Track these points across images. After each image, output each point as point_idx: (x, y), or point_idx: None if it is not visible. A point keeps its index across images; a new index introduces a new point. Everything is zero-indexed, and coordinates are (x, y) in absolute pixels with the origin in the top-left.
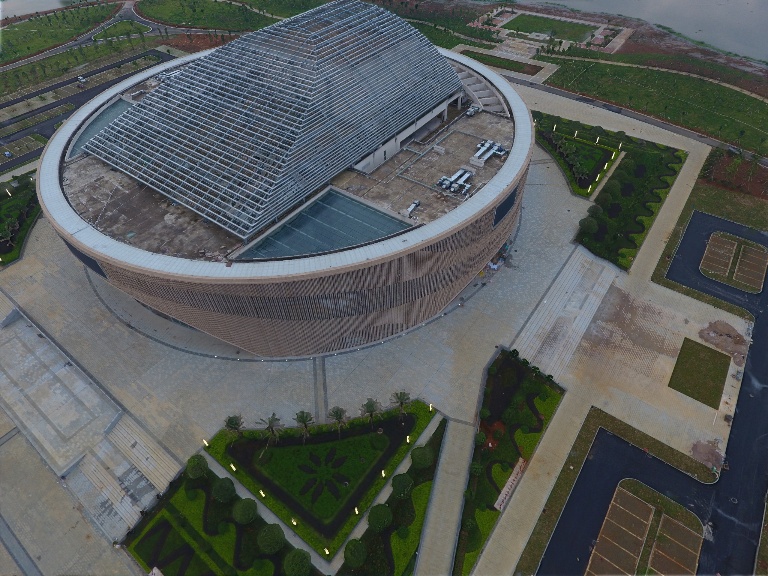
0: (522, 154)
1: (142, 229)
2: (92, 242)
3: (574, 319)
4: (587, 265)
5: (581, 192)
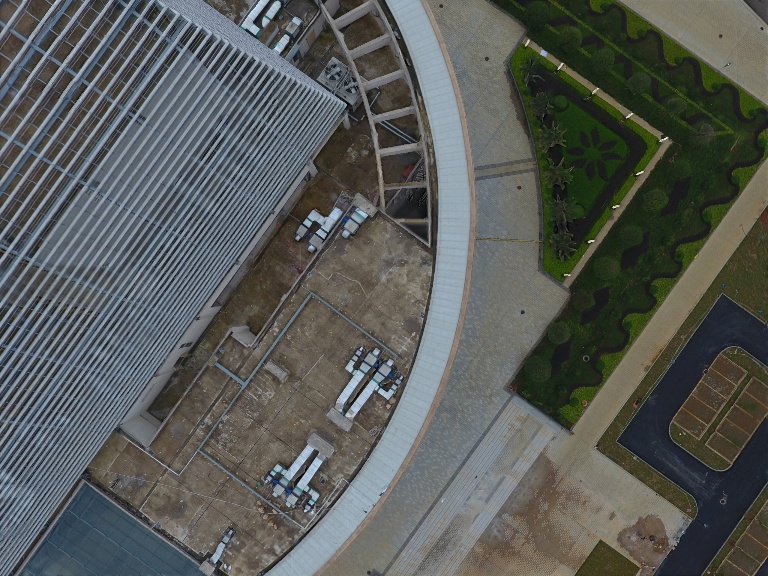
0: (425, 396)
1: None
2: None
3: (474, 519)
4: (518, 424)
5: (554, 271)
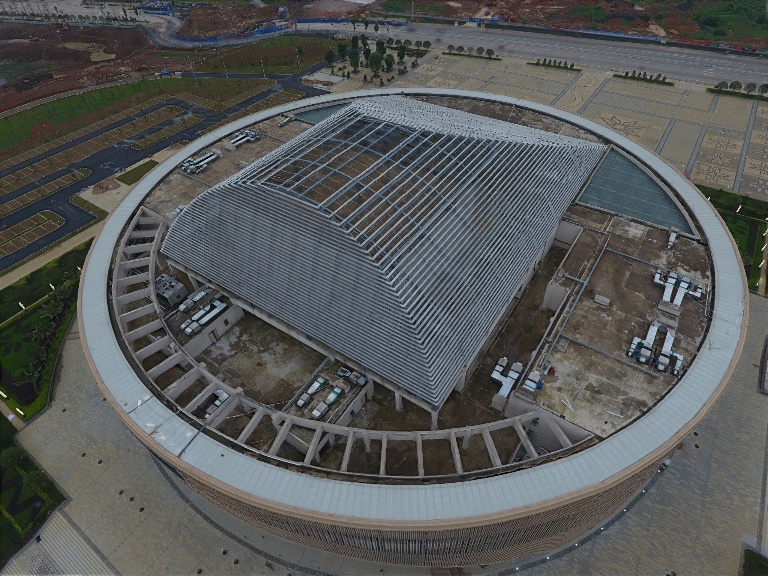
0: (171, 161)
1: (477, 107)
2: (500, 97)
3: None
4: None
5: None
